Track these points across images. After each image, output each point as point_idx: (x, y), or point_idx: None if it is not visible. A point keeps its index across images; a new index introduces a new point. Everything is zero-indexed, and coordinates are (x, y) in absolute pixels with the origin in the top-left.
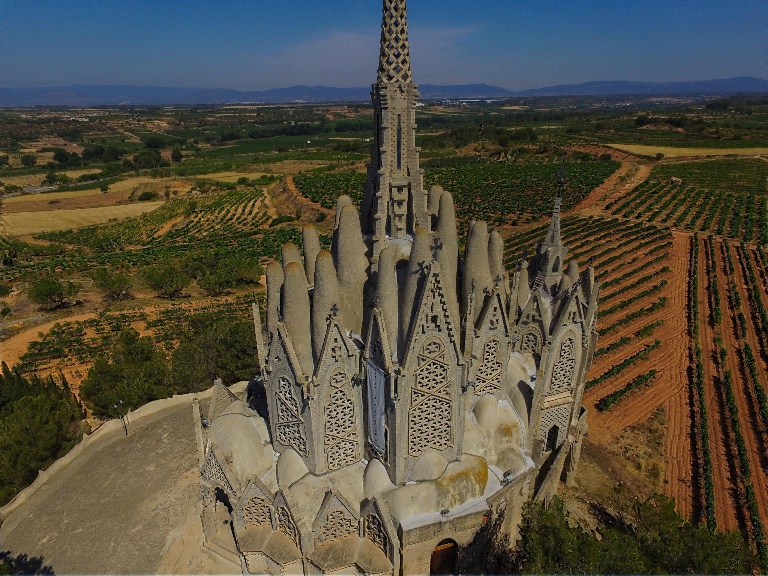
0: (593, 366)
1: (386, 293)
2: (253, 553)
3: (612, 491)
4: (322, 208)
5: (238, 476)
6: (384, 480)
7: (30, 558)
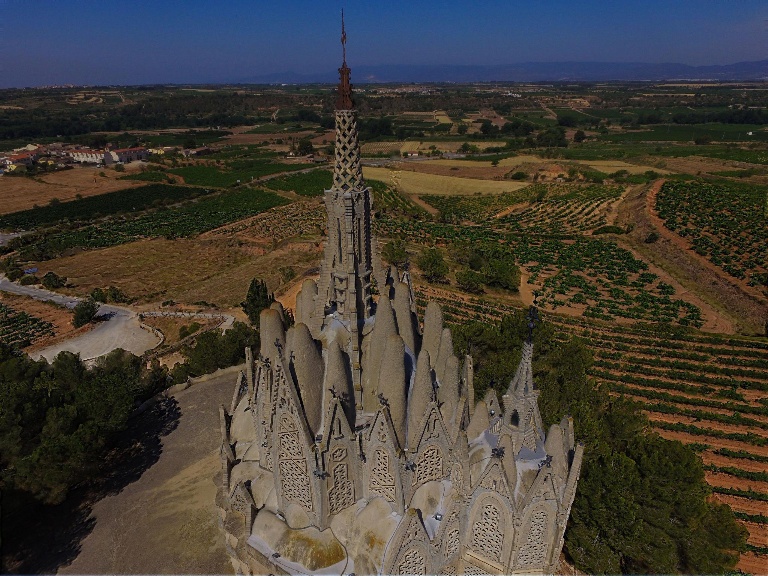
0: None
1: None
2: None
3: None
4: (663, 227)
5: (232, 434)
6: (276, 501)
7: (180, 412)
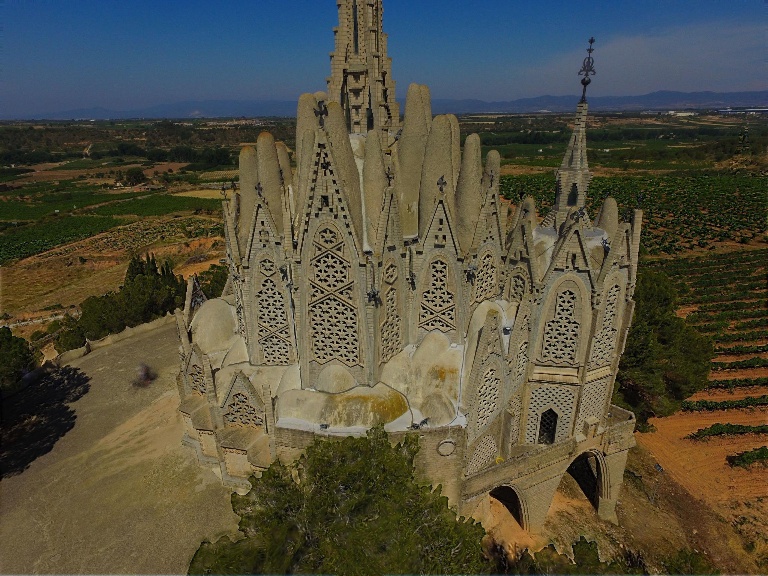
0: (758, 414)
1: (303, 176)
2: (187, 415)
3: (674, 552)
4: (511, 205)
5: None
6: (294, 382)
7: (85, 376)
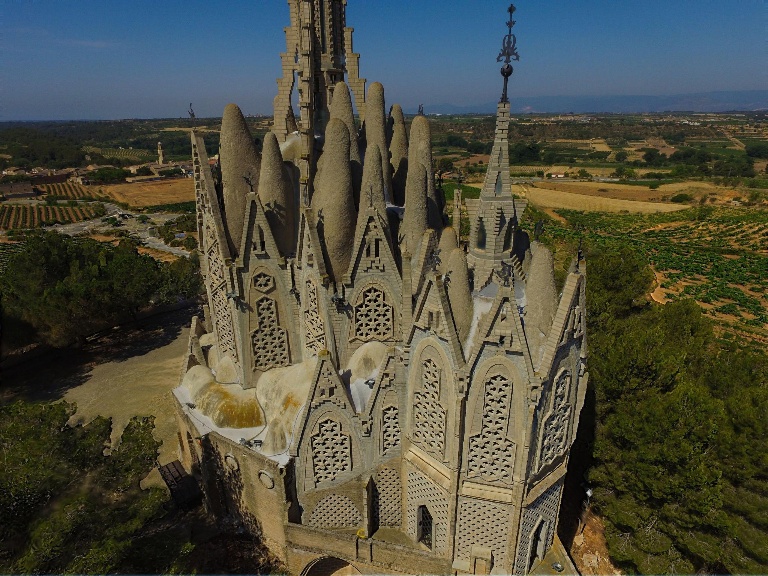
0: None
1: None
2: None
3: None
4: None
5: None
6: None
7: None
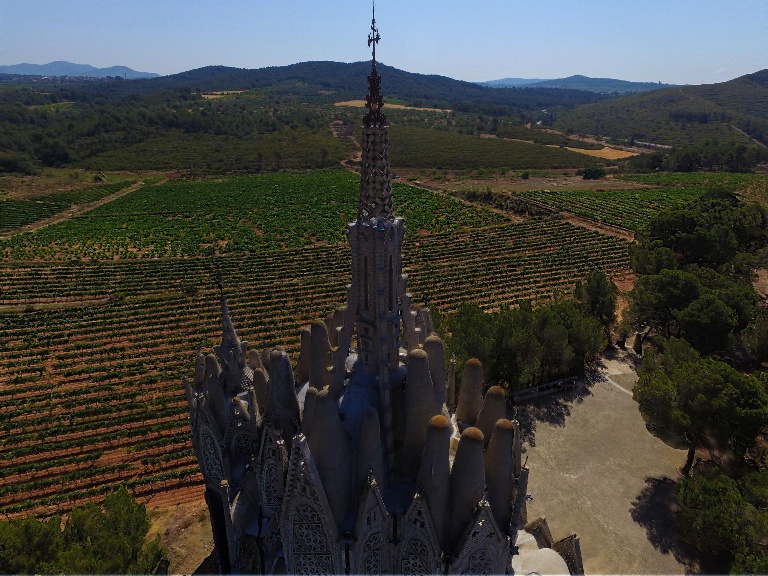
0: None
1: None
2: None
3: (207, 520)
4: None
5: None
6: None
7: None
